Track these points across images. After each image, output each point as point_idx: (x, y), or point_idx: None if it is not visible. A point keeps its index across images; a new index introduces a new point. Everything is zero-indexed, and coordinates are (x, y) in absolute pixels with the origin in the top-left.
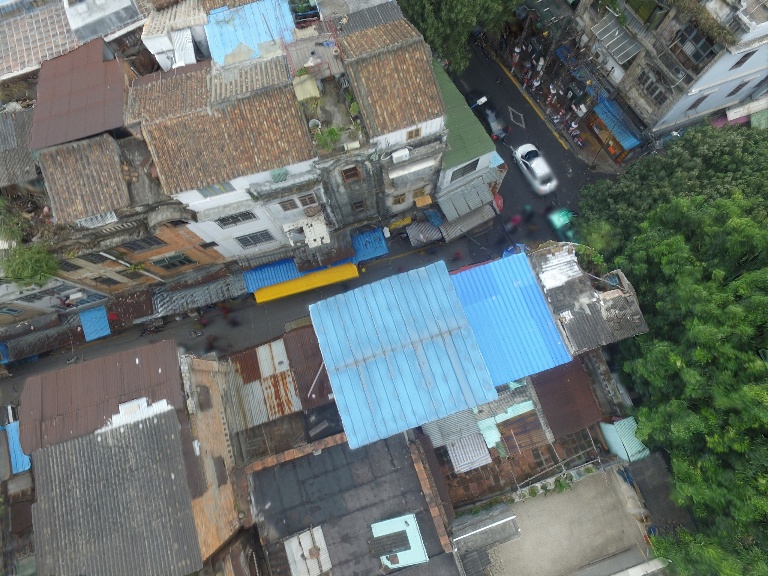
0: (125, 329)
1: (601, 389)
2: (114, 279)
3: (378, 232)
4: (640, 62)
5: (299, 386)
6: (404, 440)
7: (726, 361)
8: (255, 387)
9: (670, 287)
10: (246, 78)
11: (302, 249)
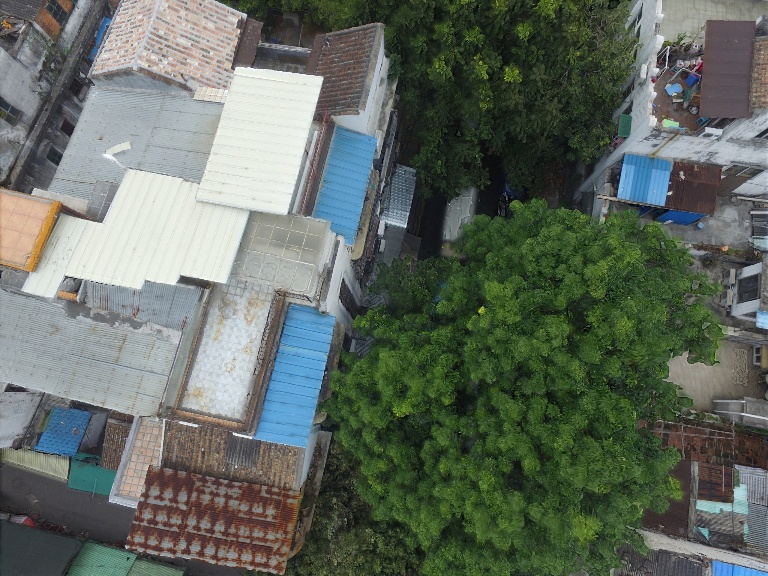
0: None
1: None
2: None
3: None
4: None
5: None
6: None
7: None
8: None
9: None
10: None
11: None
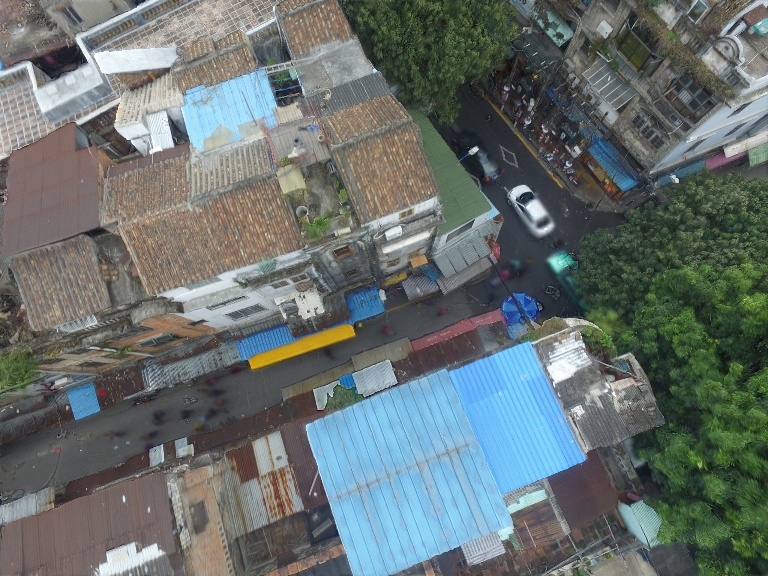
0: (115, 404)
1: (614, 462)
2: (100, 362)
3: (373, 290)
4: (634, 106)
5: (299, 483)
6: None
7: (752, 469)
8: (253, 486)
9: (684, 370)
10: (227, 167)
11: None
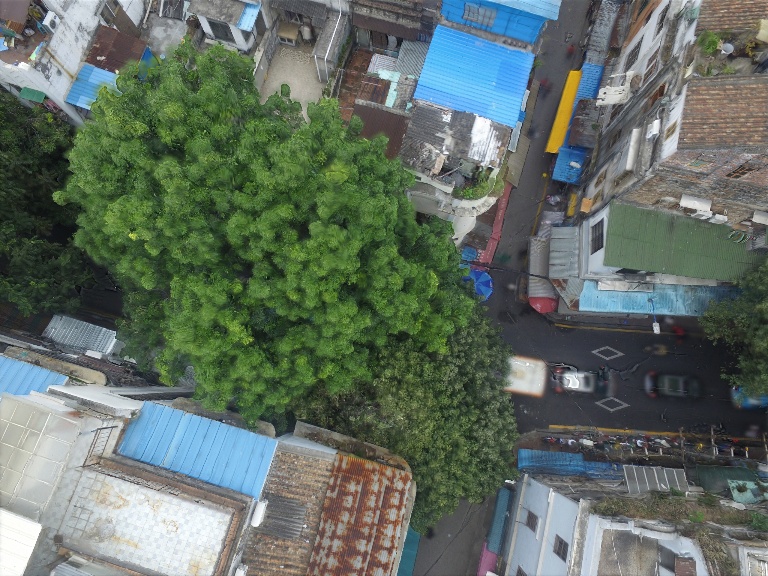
0: None
1: None
2: None
3: None
4: None
5: None
6: (427, 7)
7: None
8: None
9: None
10: None
11: (599, 108)
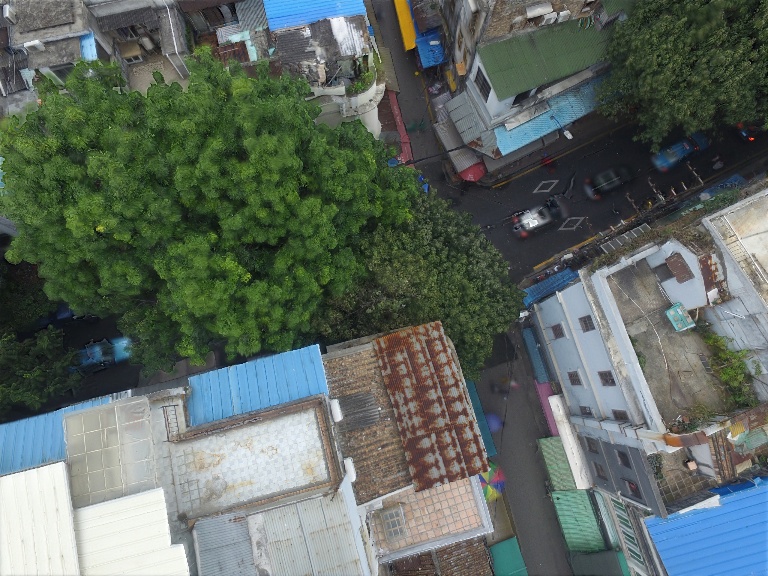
0: None
1: None
2: None
3: None
4: None
5: None
6: None
7: None
8: None
9: None
10: None
11: None
